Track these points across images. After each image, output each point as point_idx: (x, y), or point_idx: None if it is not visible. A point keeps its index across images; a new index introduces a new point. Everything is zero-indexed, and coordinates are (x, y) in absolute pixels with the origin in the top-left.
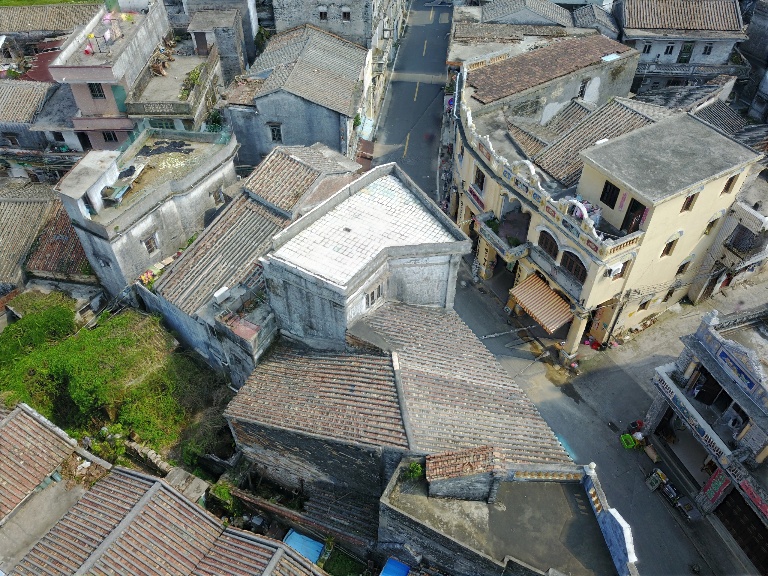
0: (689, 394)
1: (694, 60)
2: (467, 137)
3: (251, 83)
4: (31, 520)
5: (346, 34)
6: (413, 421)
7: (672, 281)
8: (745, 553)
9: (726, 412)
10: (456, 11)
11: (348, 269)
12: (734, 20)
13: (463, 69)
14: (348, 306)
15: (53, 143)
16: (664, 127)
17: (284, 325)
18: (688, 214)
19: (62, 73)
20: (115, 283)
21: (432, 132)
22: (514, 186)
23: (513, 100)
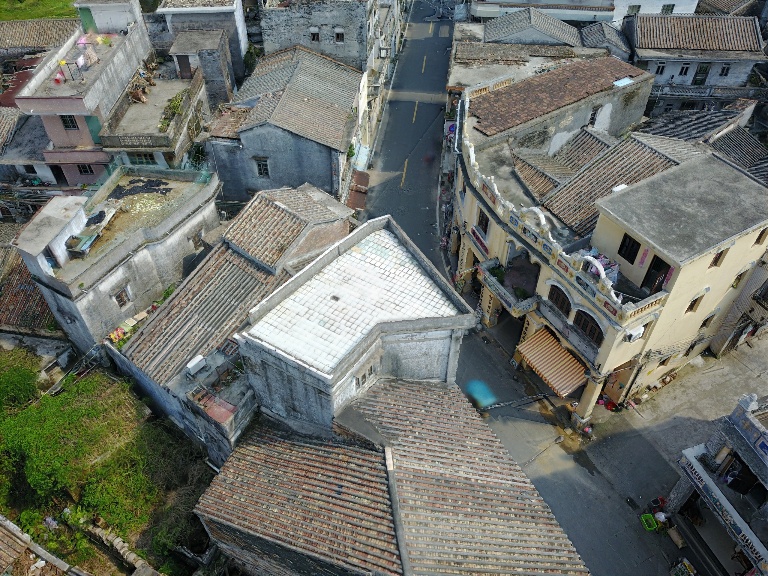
0: (721, 480)
1: (710, 81)
2: (469, 175)
3: (236, 112)
4: None
5: (339, 56)
6: (409, 538)
7: (695, 335)
8: None
9: (765, 505)
10: (457, 29)
11: (335, 349)
12: (754, 39)
13: (465, 97)
14: (335, 394)
15: (24, 175)
16: (688, 170)
17: (265, 403)
18: (716, 270)
19: (29, 104)
20: (83, 340)
21: (432, 157)
22: (522, 234)
23: (519, 132)
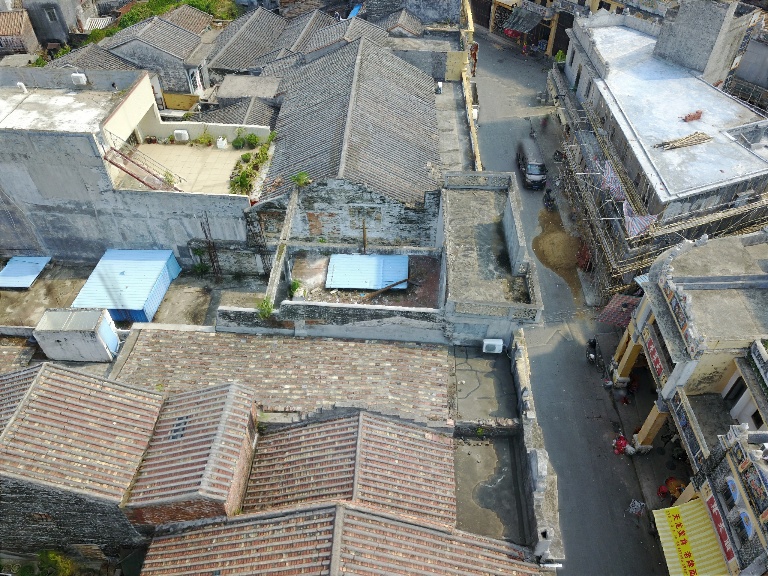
0: None
1: None
2: None
3: None
4: (209, 36)
5: None
6: None
7: None
8: (482, 26)
9: None
10: None
11: None
12: None
13: None
14: None
15: None
16: None
17: None
18: None
19: None
20: None
21: None
22: None
23: None
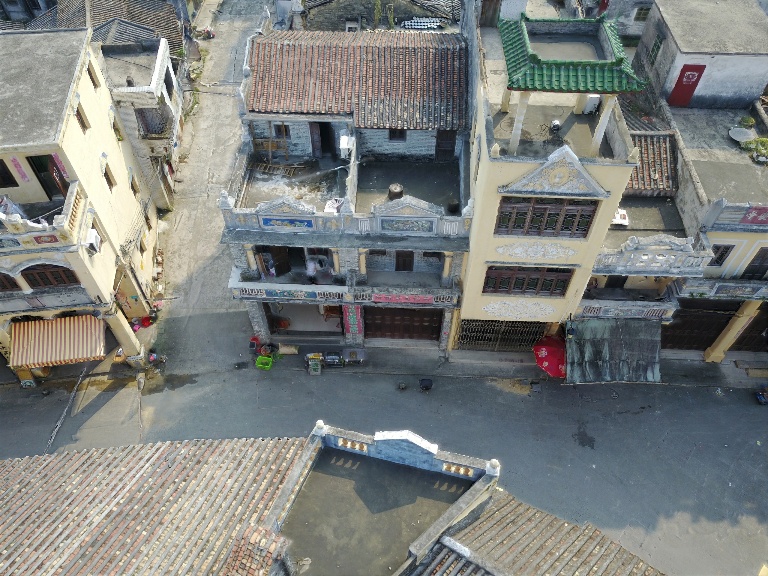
0: (269, 278)
1: None
2: None
3: None
4: None
5: None
6: None
7: (138, 206)
8: (407, 339)
9: (307, 263)
10: None
11: None
12: None
13: None
14: None
15: None
16: None
17: None
18: (91, 132)
19: None
20: None
21: None
22: None
23: None
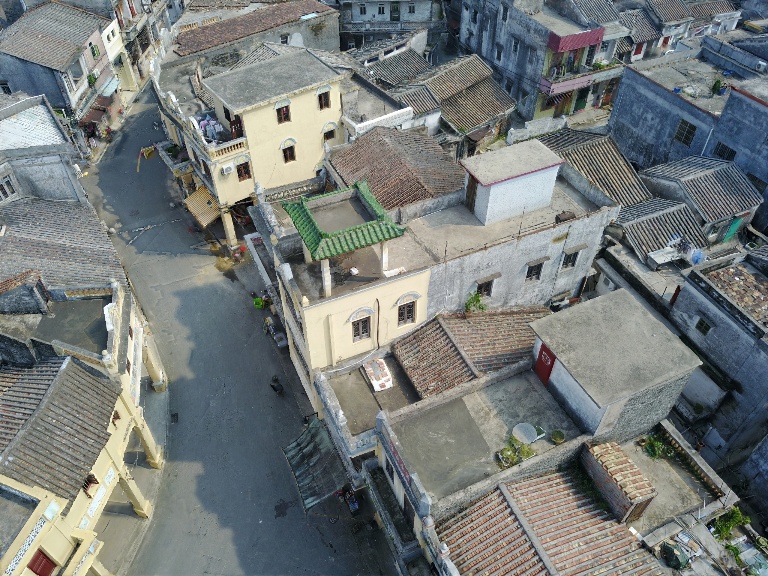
0: None
1: (404, 18)
2: None
3: None
4: None
5: (89, 7)
6: None
7: None
8: None
9: None
10: None
11: None
12: None
13: (173, 30)
14: None
15: None
16: (281, 60)
17: None
18: (290, 124)
19: None
20: None
21: None
22: (172, 115)
23: (208, 52)
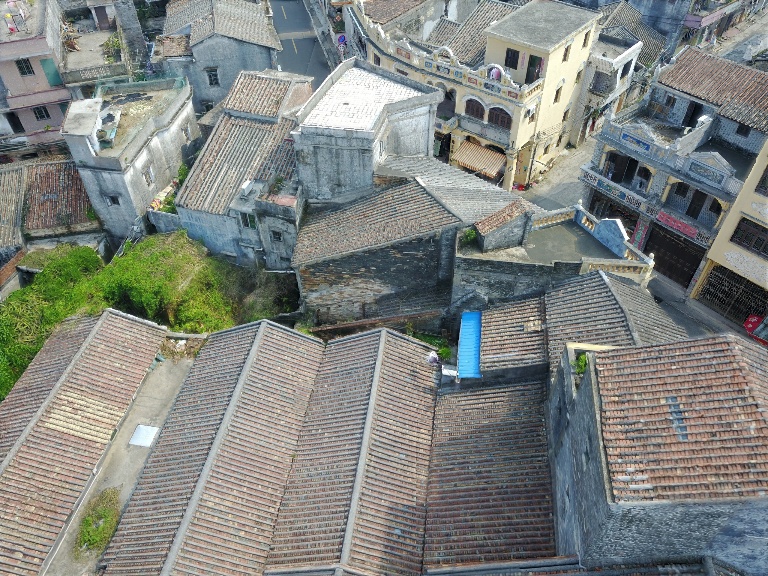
0: None
1: None
2: (382, 48)
3: (174, 39)
4: (157, 390)
5: None
6: (454, 209)
7: (560, 127)
8: (667, 277)
9: (633, 181)
10: None
11: (364, 125)
12: None
13: (353, 2)
14: (374, 150)
15: None
16: (531, 8)
17: (311, 194)
18: (566, 64)
19: None
20: (122, 220)
21: (324, 74)
22: (436, 72)
23: (403, 19)
